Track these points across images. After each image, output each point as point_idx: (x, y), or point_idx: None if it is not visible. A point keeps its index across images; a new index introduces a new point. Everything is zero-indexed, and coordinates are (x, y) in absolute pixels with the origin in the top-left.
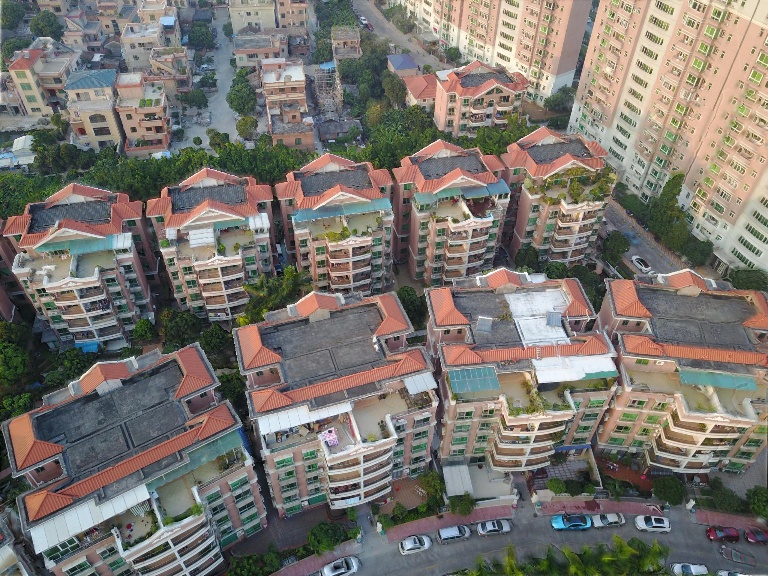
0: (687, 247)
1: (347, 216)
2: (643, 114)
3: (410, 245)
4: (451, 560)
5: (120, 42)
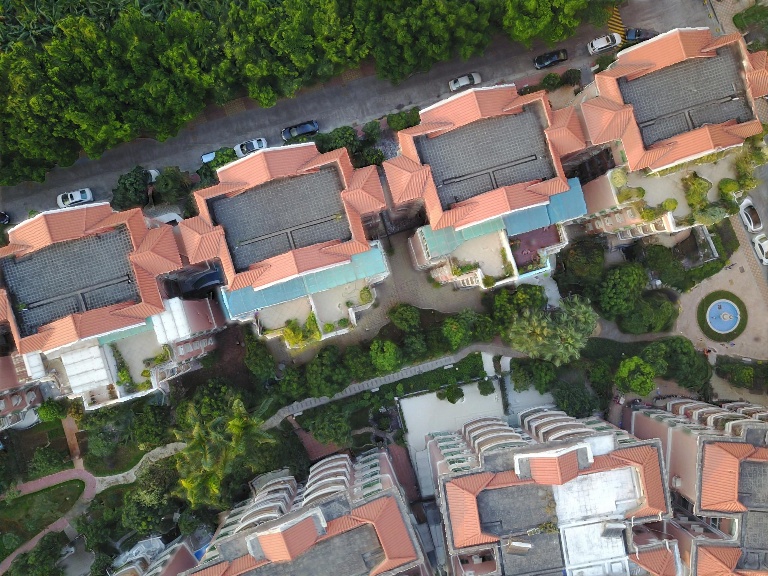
0: None
1: (312, 293)
2: None
3: (412, 243)
4: None
5: None
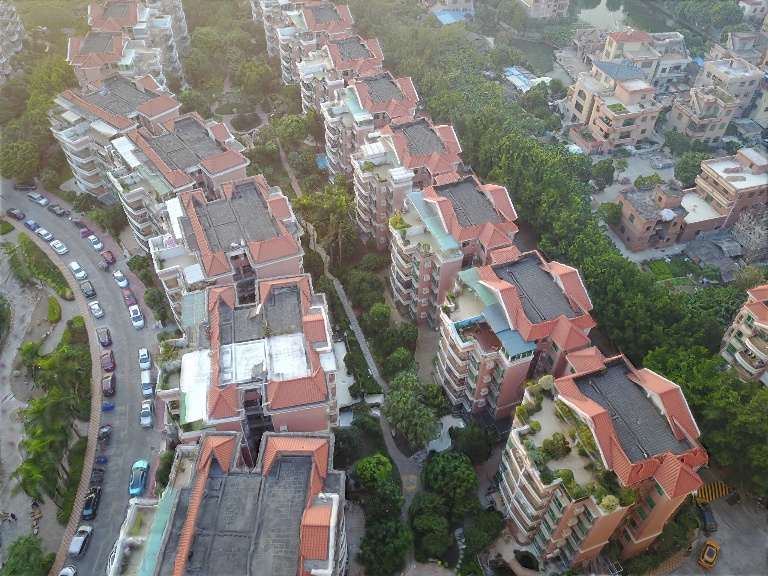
0: None
1: None
2: None
3: None
4: (127, 383)
5: (702, 65)
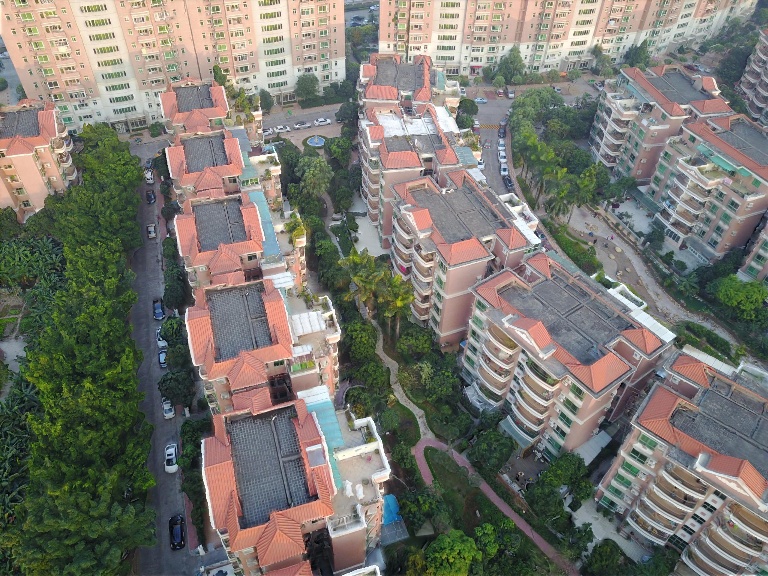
0: (260, 103)
1: None
2: (125, 60)
3: None
4: None
5: None
